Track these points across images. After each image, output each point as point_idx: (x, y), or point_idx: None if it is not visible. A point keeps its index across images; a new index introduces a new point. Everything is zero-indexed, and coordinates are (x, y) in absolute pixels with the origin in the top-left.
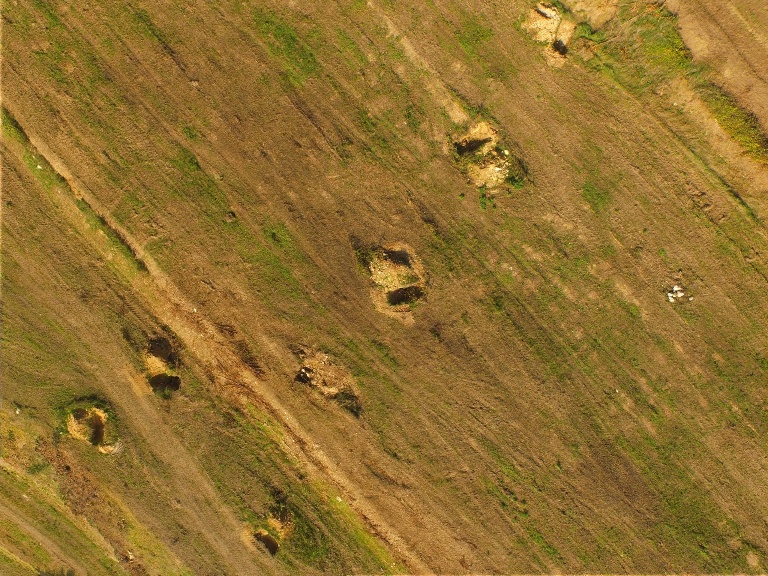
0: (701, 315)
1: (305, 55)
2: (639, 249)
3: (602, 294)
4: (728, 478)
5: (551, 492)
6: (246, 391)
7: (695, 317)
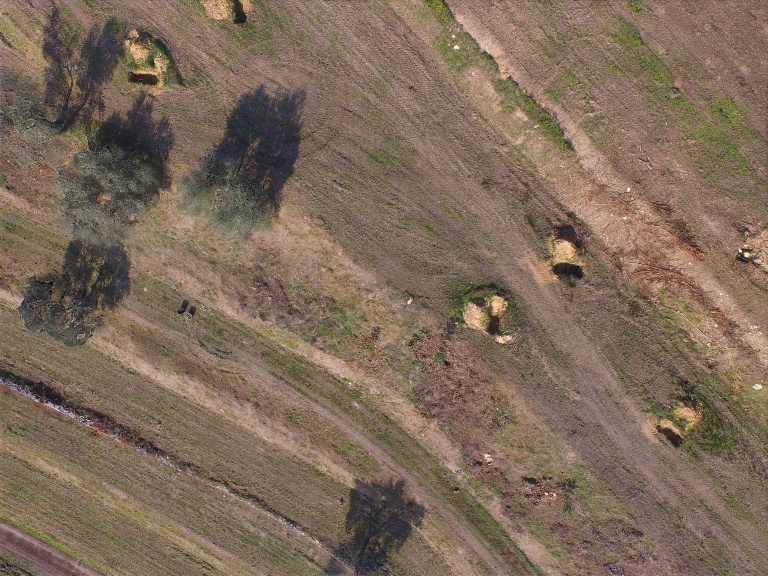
0: None
1: None
2: None
3: None
4: None
5: None
6: (669, 275)
7: None
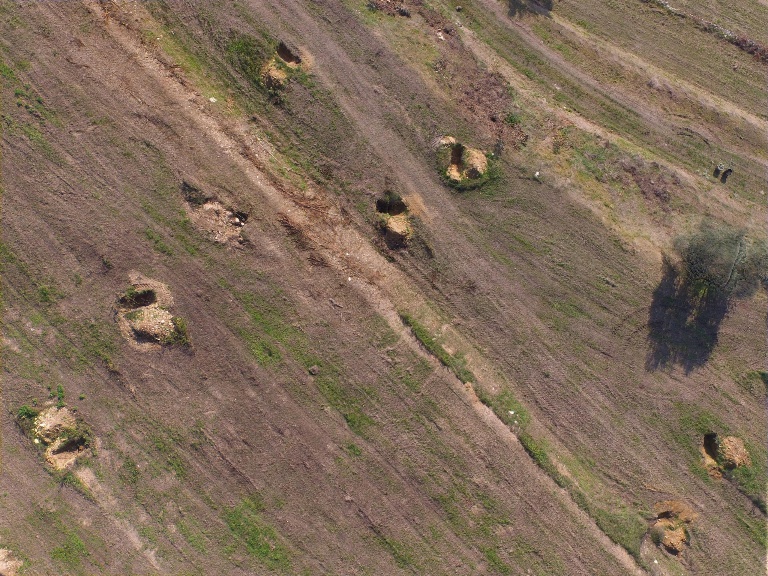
0: None
1: (239, 529)
2: None
3: None
4: None
5: None
6: (304, 202)
7: None
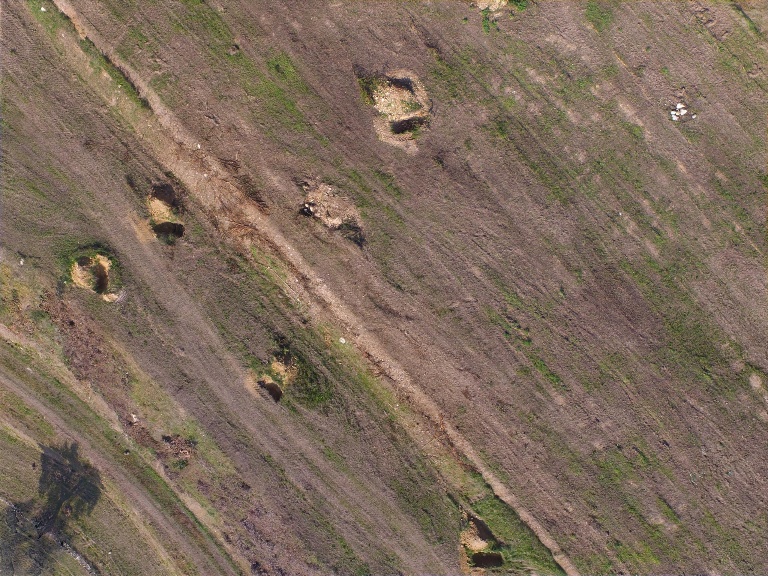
0: (704, 133)
1: None
2: (642, 67)
3: (605, 115)
4: (731, 299)
5: (554, 319)
6: (250, 231)
7: (698, 135)
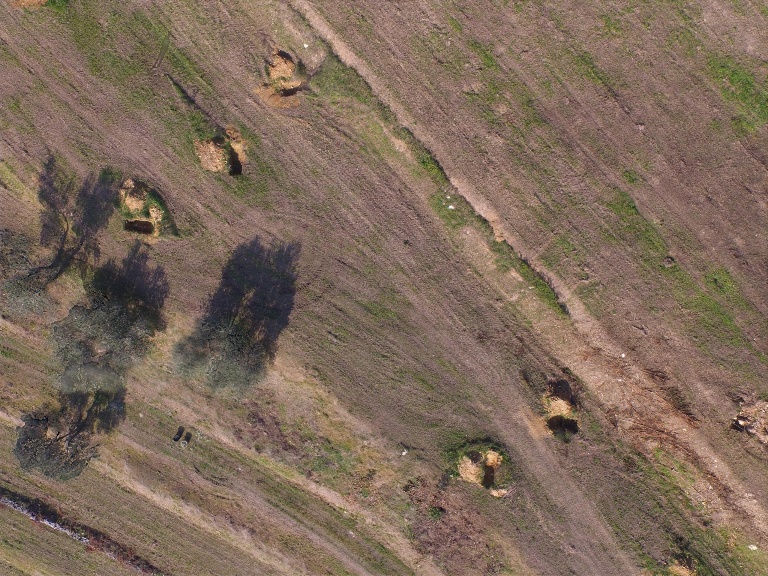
0: None
1: (762, 100)
2: None
3: None
4: None
5: None
6: (663, 437)
7: None
